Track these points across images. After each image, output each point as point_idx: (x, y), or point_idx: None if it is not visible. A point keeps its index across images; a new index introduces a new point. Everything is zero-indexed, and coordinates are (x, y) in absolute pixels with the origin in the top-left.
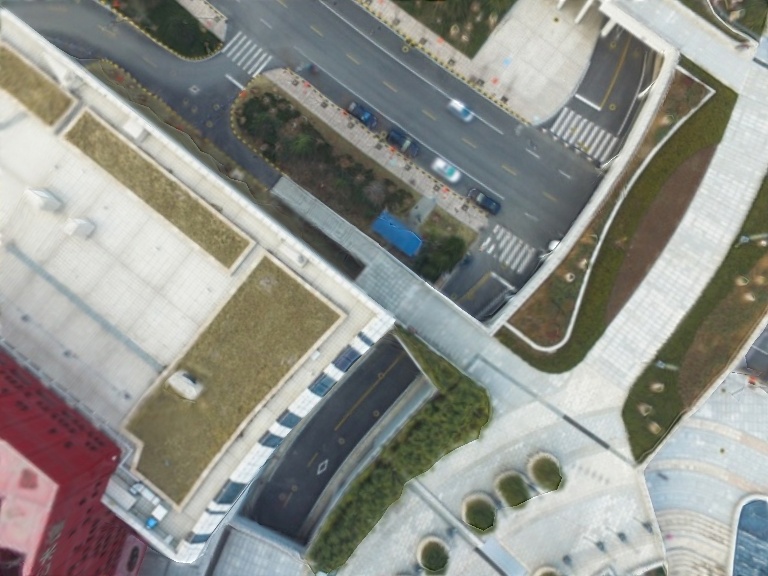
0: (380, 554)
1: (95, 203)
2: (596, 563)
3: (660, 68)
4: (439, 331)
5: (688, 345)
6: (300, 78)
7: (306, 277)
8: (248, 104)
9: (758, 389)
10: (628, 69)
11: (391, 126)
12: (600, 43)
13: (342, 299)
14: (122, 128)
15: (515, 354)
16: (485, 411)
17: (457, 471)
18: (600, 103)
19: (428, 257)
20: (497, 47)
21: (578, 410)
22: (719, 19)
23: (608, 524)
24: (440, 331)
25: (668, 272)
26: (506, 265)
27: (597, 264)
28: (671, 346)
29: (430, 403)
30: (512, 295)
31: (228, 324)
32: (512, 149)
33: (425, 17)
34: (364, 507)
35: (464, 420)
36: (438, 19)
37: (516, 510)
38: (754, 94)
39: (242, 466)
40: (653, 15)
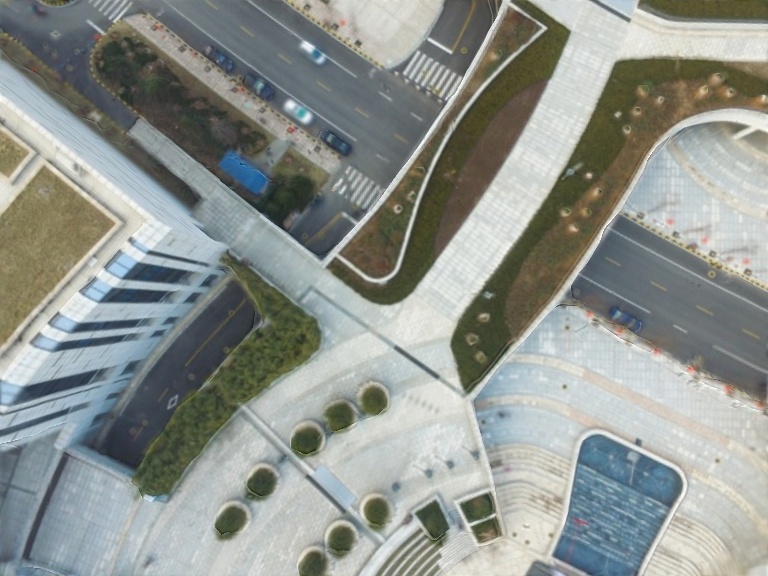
0: (213, 481)
1: None
2: (424, 491)
3: (499, 7)
4: (274, 263)
5: (515, 276)
6: (159, 23)
7: (84, 186)
8: (106, 48)
9: (600, 326)
10: (480, 13)
11: (247, 70)
12: None
13: (119, 207)
14: None
15: (347, 286)
16: (306, 337)
17: (289, 400)
18: (452, 46)
19: (273, 194)
20: None
21: (409, 341)
22: None
23: (437, 453)
24: (275, 263)
25: (496, 204)
26: (357, 205)
27: (426, 196)
28: (498, 277)
29: None
30: None
31: (6, 231)
32: (365, 92)
33: None
34: (186, 430)
35: (286, 346)
36: None
37: (347, 438)
38: (587, 31)
39: (13, 366)
40: None
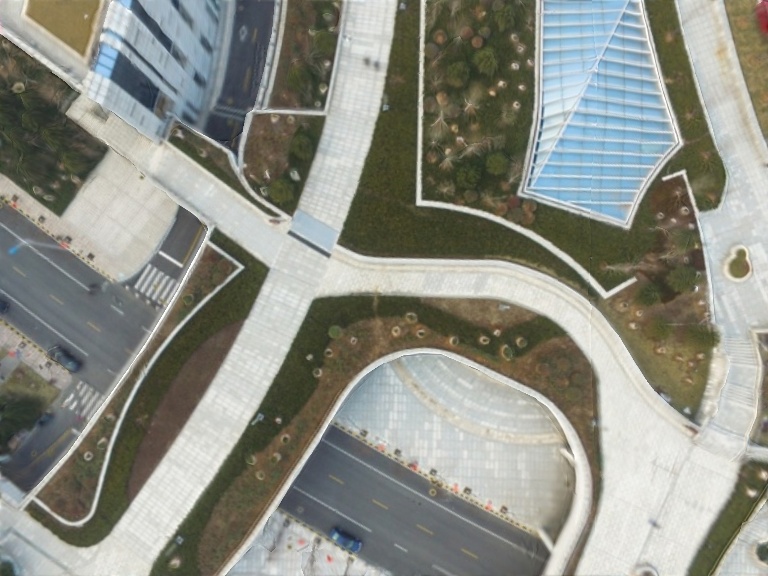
0: None
1: None
2: None
3: None
4: None
5: (206, 521)
6: None
7: None
8: None
9: (321, 547)
10: None
11: None
12: None
13: None
14: None
15: (46, 528)
16: None
17: None
18: (183, 260)
19: None
20: (85, 204)
21: None
22: (251, 194)
23: None
24: None
25: (188, 449)
26: (87, 421)
27: (118, 442)
28: (190, 522)
29: None
30: None
31: None
32: (97, 305)
33: (14, 176)
34: None
35: None
36: (24, 178)
37: None
38: (286, 267)
39: None
40: (192, 189)
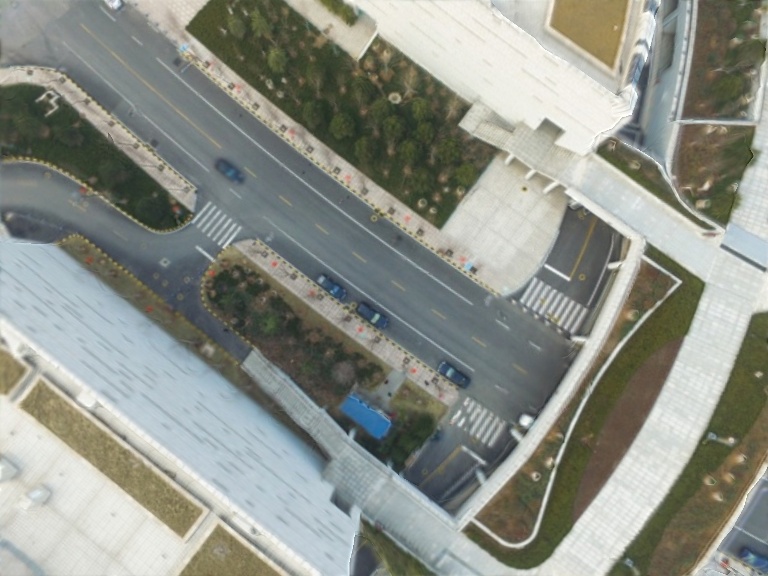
0: None
1: (50, 470)
2: None
3: (627, 251)
4: (407, 526)
5: (656, 543)
6: (270, 249)
7: (259, 545)
8: (218, 279)
9: (732, 567)
10: (597, 238)
11: (361, 297)
12: (569, 213)
13: (295, 566)
14: (75, 398)
15: (483, 549)
16: None
17: None
18: (570, 273)
19: (397, 440)
20: (466, 217)
21: None
22: (685, 207)
23: None
24: (408, 526)
25: (635, 469)
26: (477, 438)
27: (563, 461)
28: (639, 544)
29: None
30: (482, 477)
31: None
32: (482, 320)
33: (393, 188)
34: None
35: None
36: (406, 191)
37: None
38: (721, 282)
39: None
40: (618, 202)
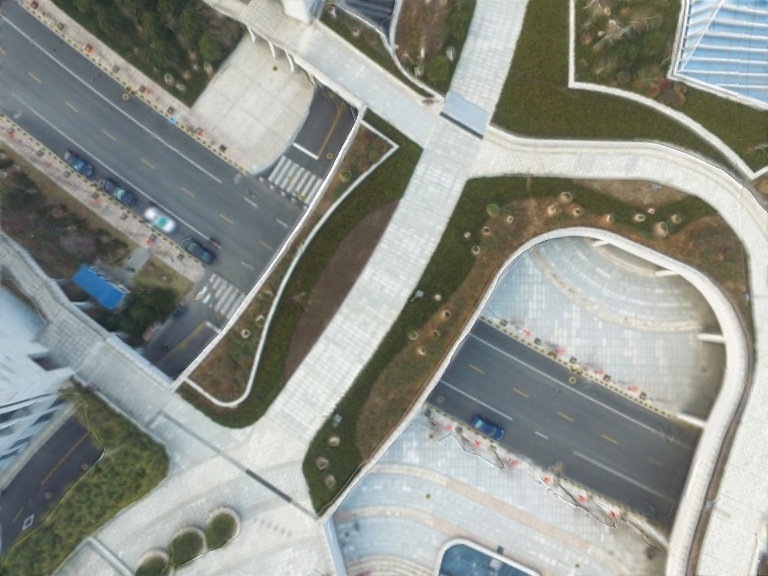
0: None
1: None
2: None
3: (355, 121)
4: (121, 388)
5: (365, 398)
6: (16, 126)
7: None
8: None
9: None
10: (345, 118)
11: (108, 175)
12: (316, 92)
13: None
14: None
15: (197, 409)
16: (147, 471)
17: (138, 528)
18: (318, 152)
19: (128, 310)
20: (216, 95)
21: (261, 464)
22: (404, 74)
23: None
24: (122, 388)
25: (346, 326)
26: (221, 314)
27: (275, 319)
28: (348, 400)
29: None
30: None
31: None
32: (230, 198)
33: (142, 65)
34: (20, 571)
35: (126, 481)
36: (154, 67)
37: (197, 566)
38: (439, 148)
39: None
40: (342, 69)
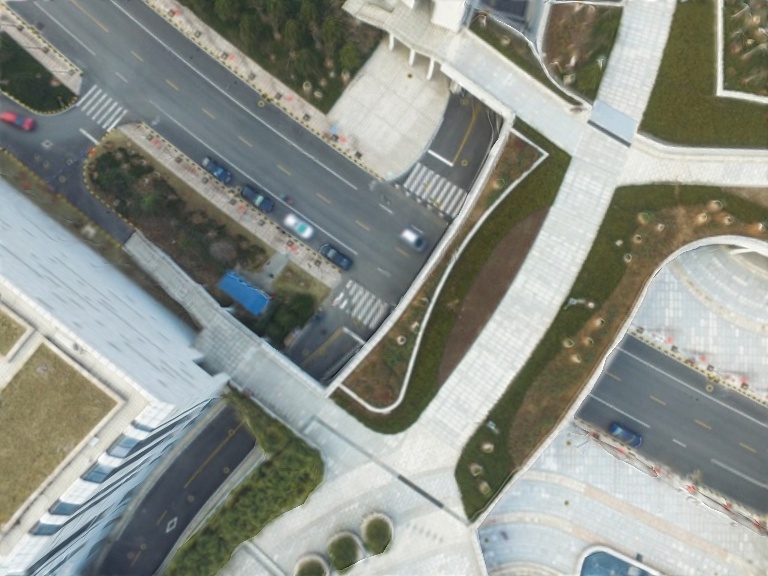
0: None
1: None
2: None
3: (500, 129)
4: (275, 393)
5: (518, 406)
6: (155, 133)
7: (84, 363)
8: (100, 159)
9: None
10: (480, 125)
11: (245, 181)
12: (452, 99)
13: (121, 385)
14: None
15: (350, 415)
16: (310, 476)
17: (292, 532)
18: (452, 159)
19: (273, 316)
20: (351, 102)
21: (413, 470)
22: (553, 82)
23: None
24: (276, 393)
25: (499, 334)
26: (358, 320)
27: (429, 326)
28: (502, 407)
29: (258, 468)
30: None
31: (3, 412)
32: (366, 204)
33: (279, 72)
34: (188, 574)
35: (290, 485)
36: (291, 75)
37: (351, 570)
38: (587, 156)
39: (12, 557)
40: (490, 78)
